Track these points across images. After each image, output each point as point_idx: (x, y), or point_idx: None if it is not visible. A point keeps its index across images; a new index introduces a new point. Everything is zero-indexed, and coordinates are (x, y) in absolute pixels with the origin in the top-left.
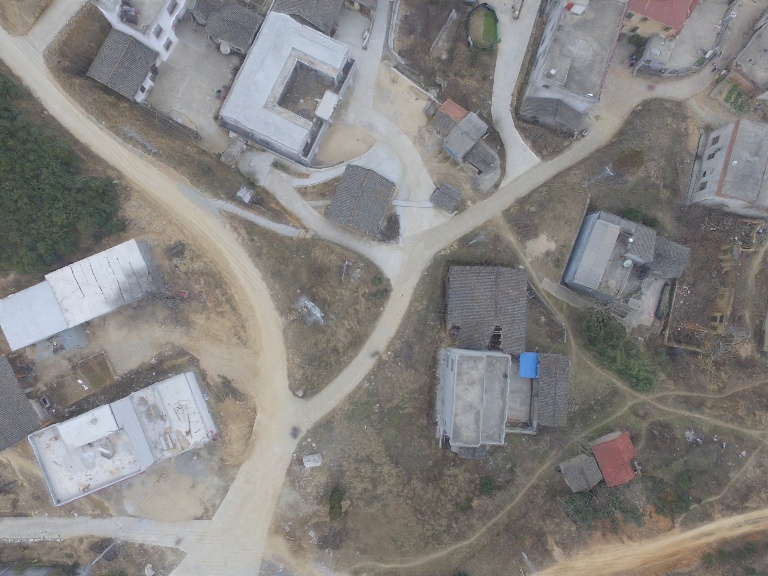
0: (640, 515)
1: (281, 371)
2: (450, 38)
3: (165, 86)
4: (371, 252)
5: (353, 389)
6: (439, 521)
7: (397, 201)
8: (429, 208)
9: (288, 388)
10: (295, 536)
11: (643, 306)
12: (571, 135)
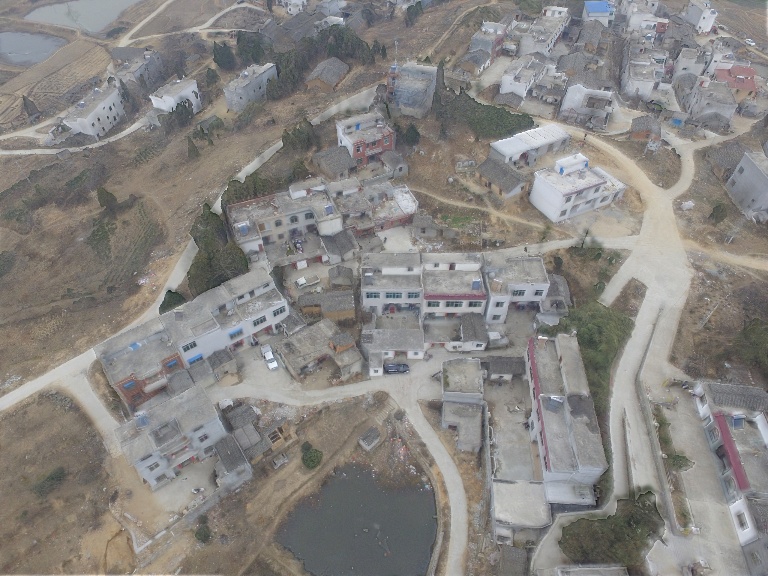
0: None
1: (644, 177)
2: (643, 108)
3: None
4: None
5: (687, 189)
6: None
7: None
8: (678, 139)
9: (652, 183)
10: (699, 239)
11: None
12: (727, 131)
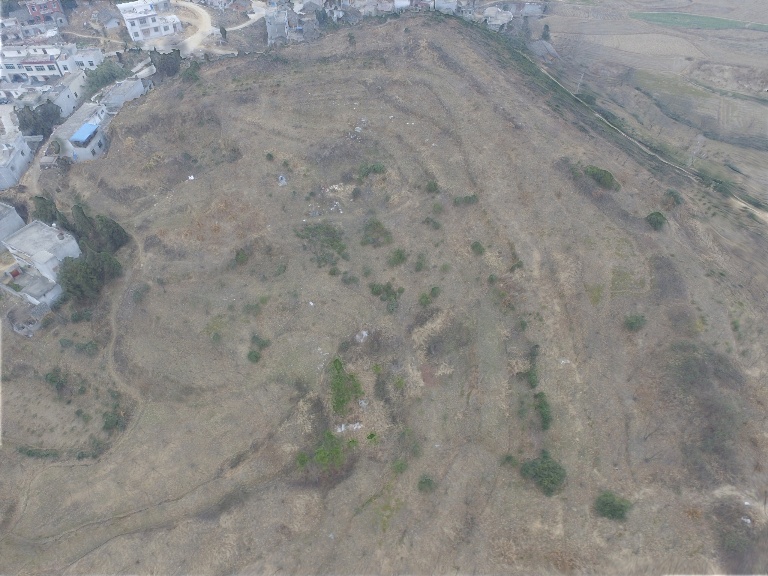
0: None
1: None
2: None
3: None
4: None
5: None
6: None
7: None
8: None
9: (211, 25)
10: None
11: None
12: None
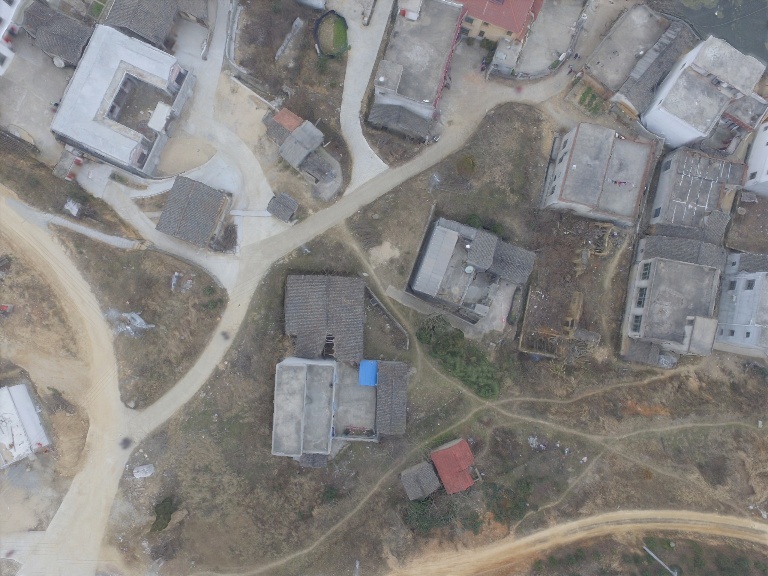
0: (479, 522)
1: (112, 383)
2: (297, 46)
3: (3, 100)
4: (208, 262)
5: (189, 399)
6: (280, 530)
7: (235, 211)
8: (268, 217)
9: (120, 399)
10: (129, 546)
11: (495, 311)
12: (422, 141)
